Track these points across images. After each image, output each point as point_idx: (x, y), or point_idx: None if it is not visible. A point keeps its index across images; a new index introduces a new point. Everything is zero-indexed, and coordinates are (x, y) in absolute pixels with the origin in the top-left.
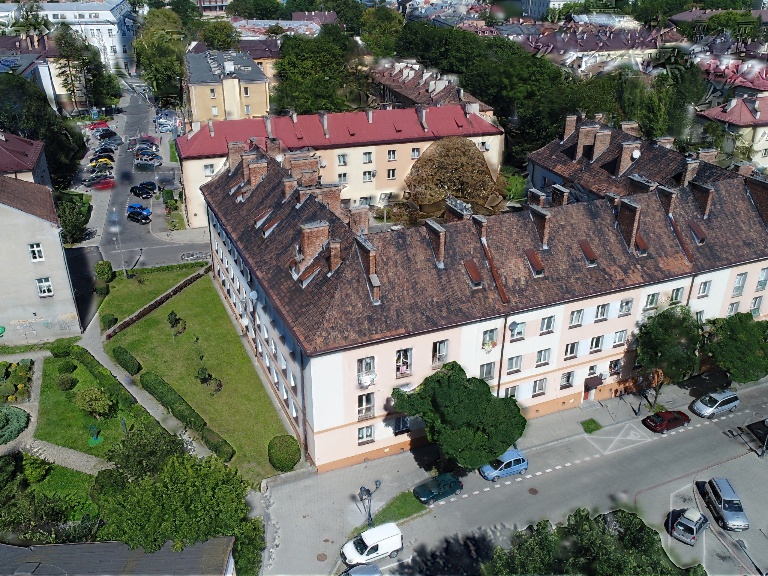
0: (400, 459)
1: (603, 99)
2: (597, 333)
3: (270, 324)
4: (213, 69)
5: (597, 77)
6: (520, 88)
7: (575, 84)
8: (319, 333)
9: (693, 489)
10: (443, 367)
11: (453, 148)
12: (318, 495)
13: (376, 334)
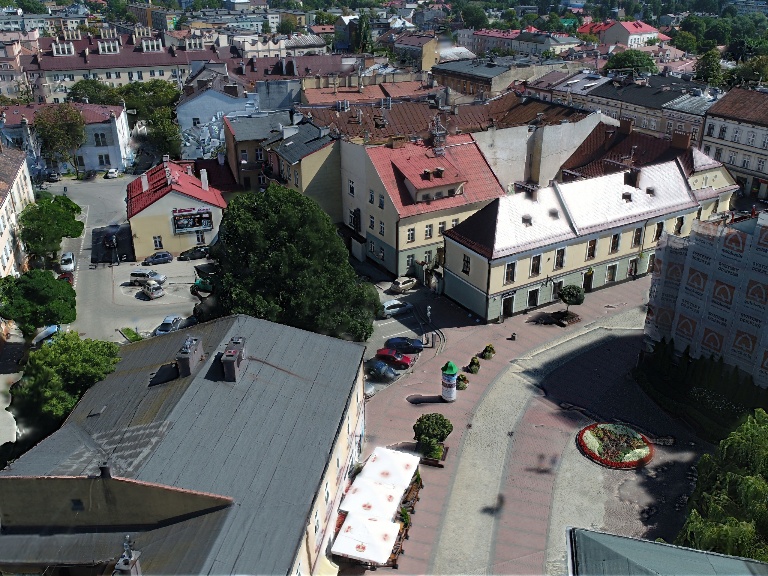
0: (0, 380)
1: None
2: (4, 245)
3: None
4: None
5: None
6: None
7: None
8: None
9: (125, 288)
10: (0, 282)
11: None
12: (5, 420)
13: None
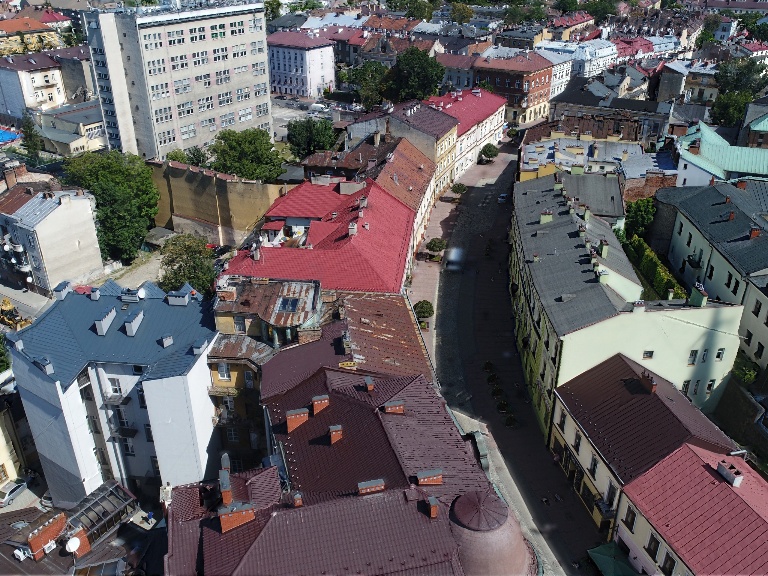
0: None
1: (612, 6)
2: None
3: None
4: (497, 8)
5: (601, 0)
6: (573, 7)
7: (592, 4)
8: None
9: None
10: None
11: (641, 13)
12: None
13: None
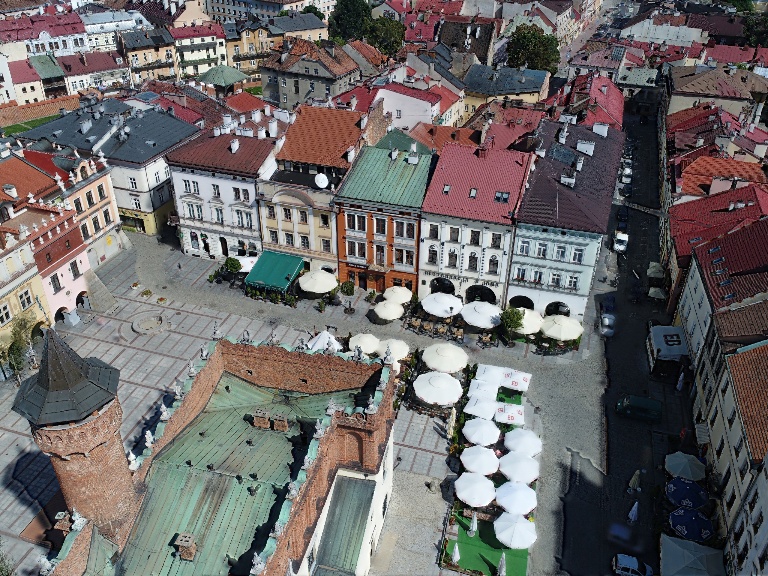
0: None
1: None
2: (328, 5)
3: (260, 10)
4: None
5: None
6: None
7: None
8: (283, 0)
9: None
10: None
11: None
12: None
13: (293, 1)
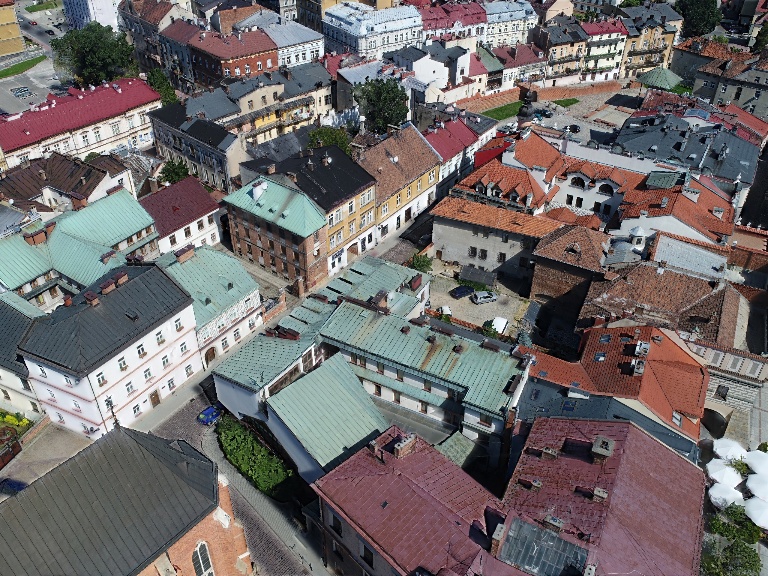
0: None
1: None
2: None
3: None
4: None
5: None
6: None
7: None
8: None
9: None
10: None
11: None
12: None
13: None
